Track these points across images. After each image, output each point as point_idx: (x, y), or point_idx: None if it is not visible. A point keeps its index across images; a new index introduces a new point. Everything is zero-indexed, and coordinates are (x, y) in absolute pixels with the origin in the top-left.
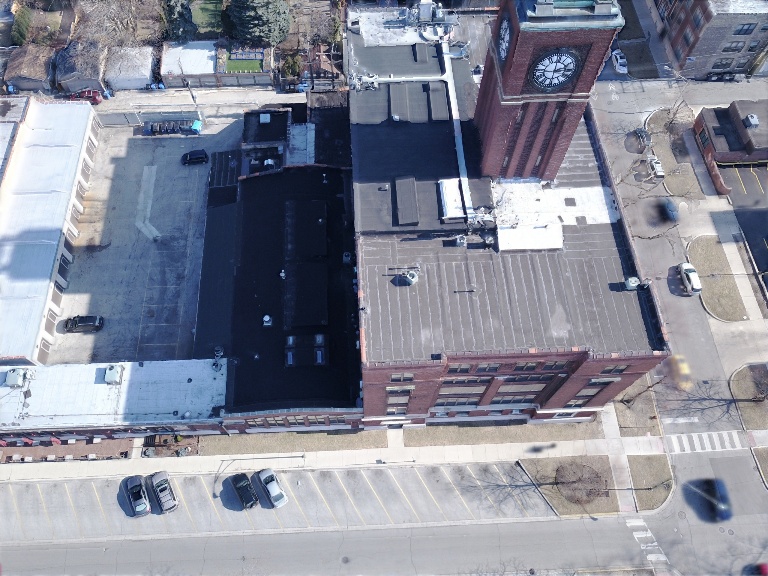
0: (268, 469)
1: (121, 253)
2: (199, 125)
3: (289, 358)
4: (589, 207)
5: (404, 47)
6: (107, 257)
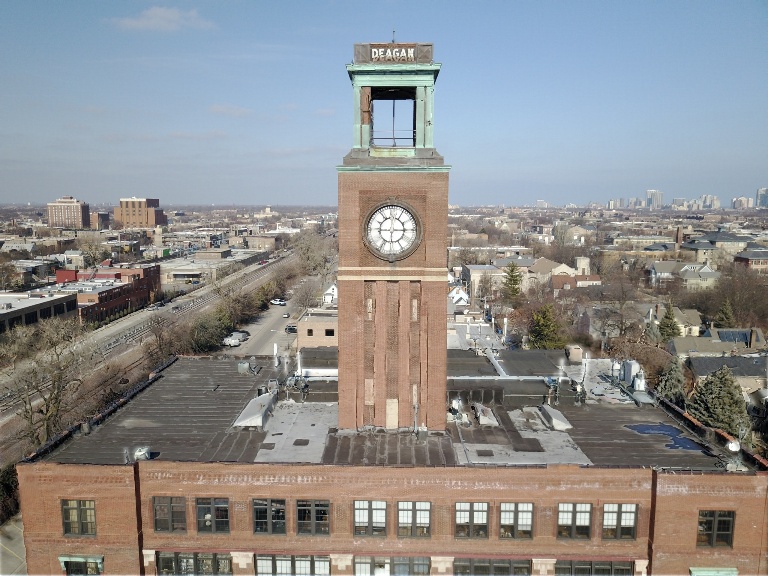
0: None
1: None
2: None
3: None
4: (288, 453)
5: None
6: None
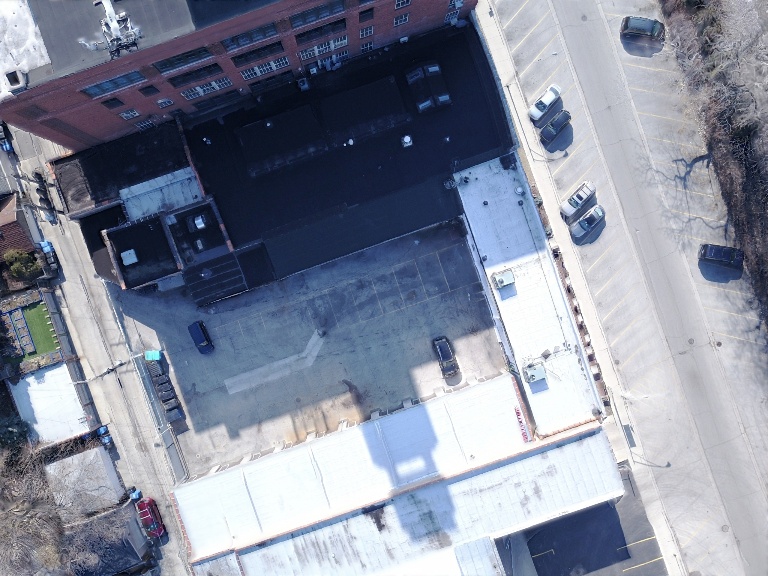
0: (530, 113)
1: (352, 363)
2: (151, 352)
3: (444, 100)
4: None
5: (35, 3)
6: (361, 375)
